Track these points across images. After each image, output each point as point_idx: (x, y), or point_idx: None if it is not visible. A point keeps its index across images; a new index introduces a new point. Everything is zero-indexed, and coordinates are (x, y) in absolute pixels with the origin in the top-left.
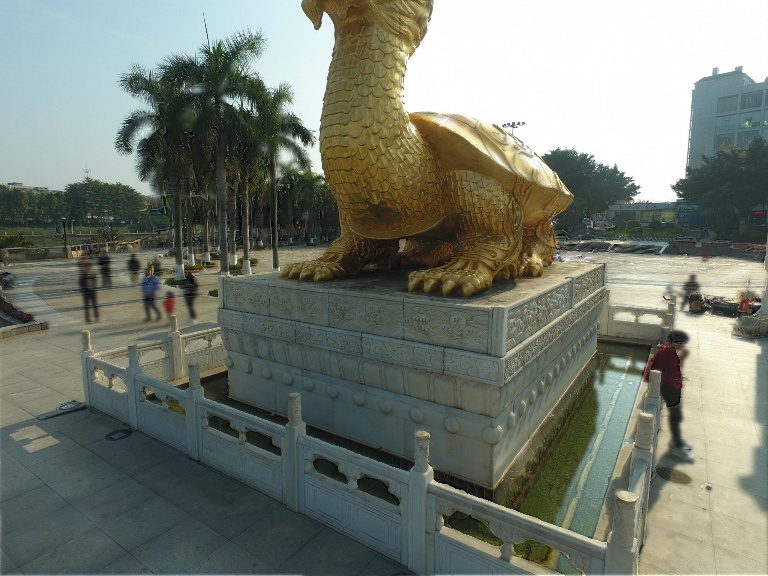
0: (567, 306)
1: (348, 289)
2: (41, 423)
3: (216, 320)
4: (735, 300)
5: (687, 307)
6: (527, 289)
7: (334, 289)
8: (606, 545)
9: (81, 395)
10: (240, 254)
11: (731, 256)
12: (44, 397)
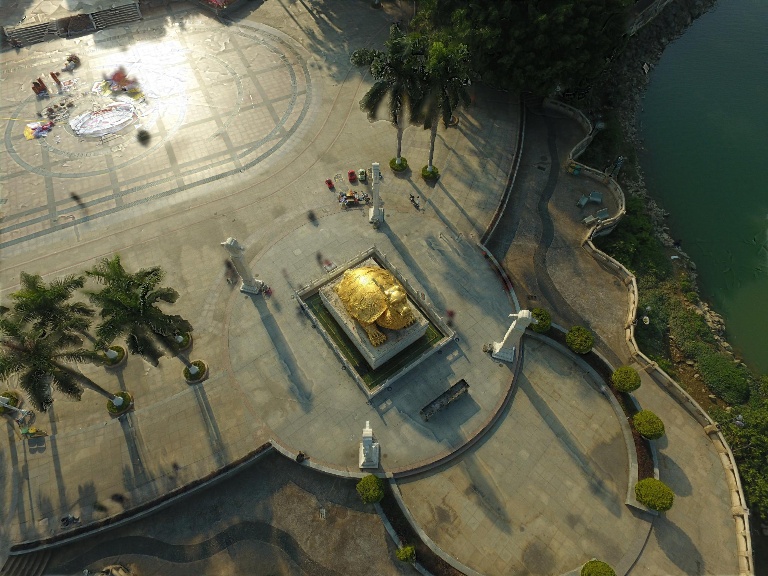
0: None
1: (400, 337)
2: (378, 405)
3: (285, 374)
4: (347, 193)
5: (323, 190)
6: (409, 306)
7: (399, 339)
8: (453, 335)
9: (363, 402)
10: None
11: (189, 1)
12: (361, 410)
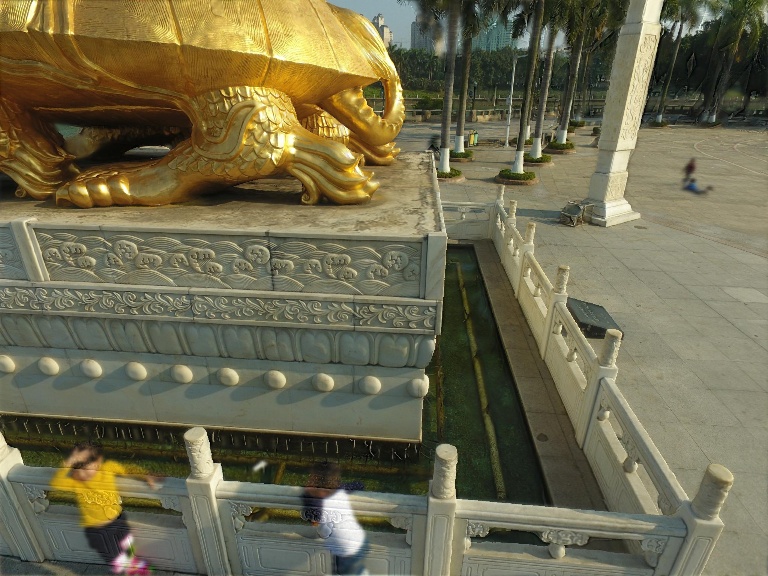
0: (6, 271)
1: None
2: None
3: None
4: None
5: None
6: None
7: None
8: None
9: None
10: (659, 131)
11: None
12: None
